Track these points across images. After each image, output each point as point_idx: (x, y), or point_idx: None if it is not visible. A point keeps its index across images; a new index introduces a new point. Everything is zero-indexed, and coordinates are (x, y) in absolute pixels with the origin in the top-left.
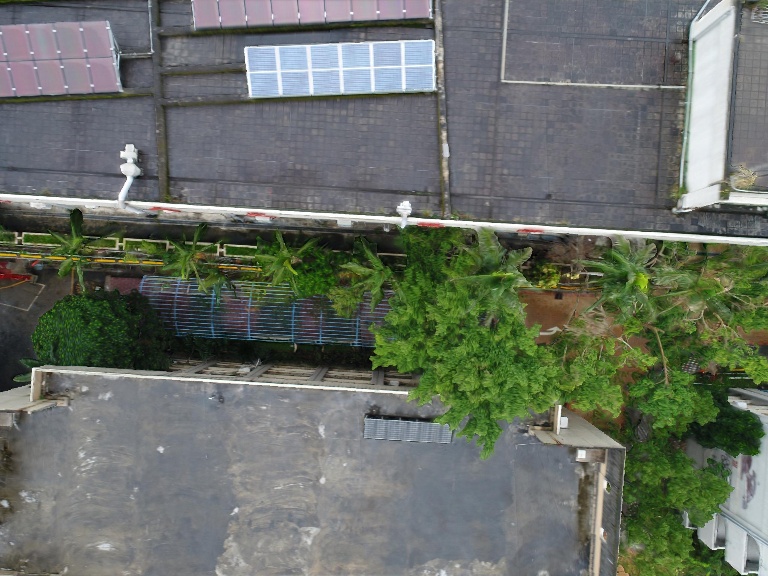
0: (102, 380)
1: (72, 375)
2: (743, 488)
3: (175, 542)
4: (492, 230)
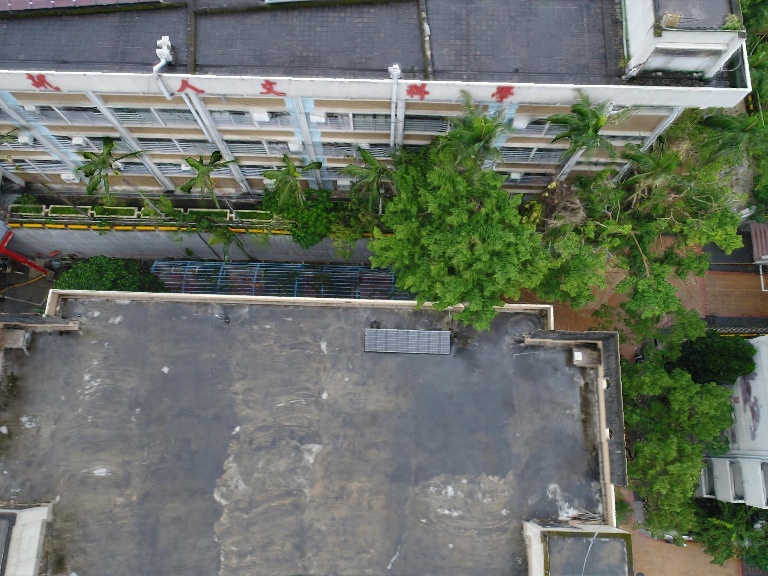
0: (114, 305)
1: (86, 301)
2: (748, 419)
3: (174, 464)
4: (470, 93)
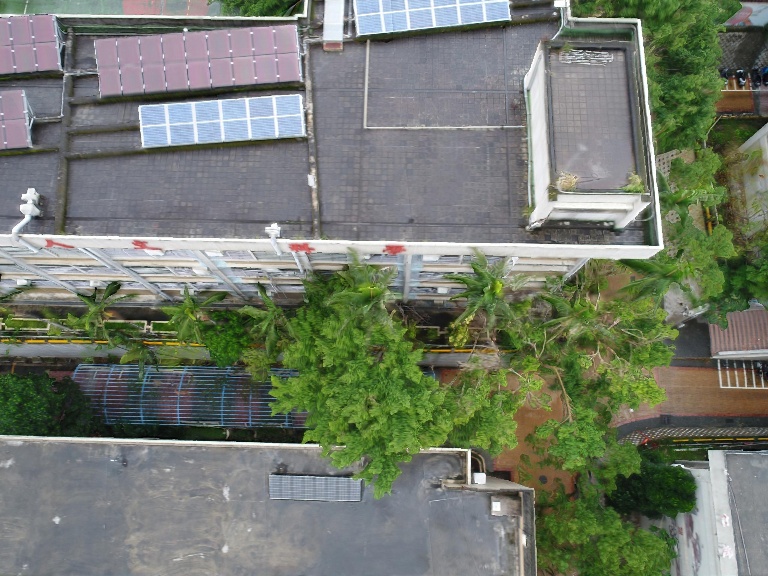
0: (5, 447)
1: None
2: (691, 556)
3: None
4: (358, 250)
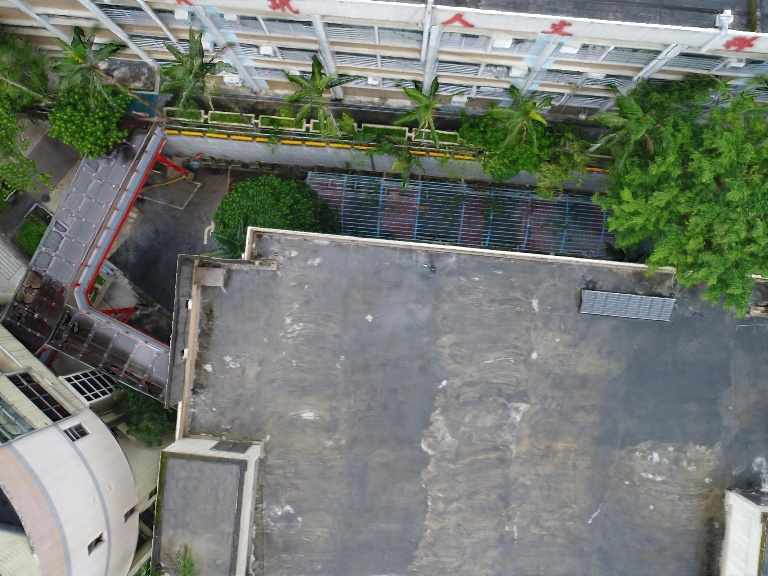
0: (312, 245)
1: (282, 239)
2: None
3: (381, 413)
4: None
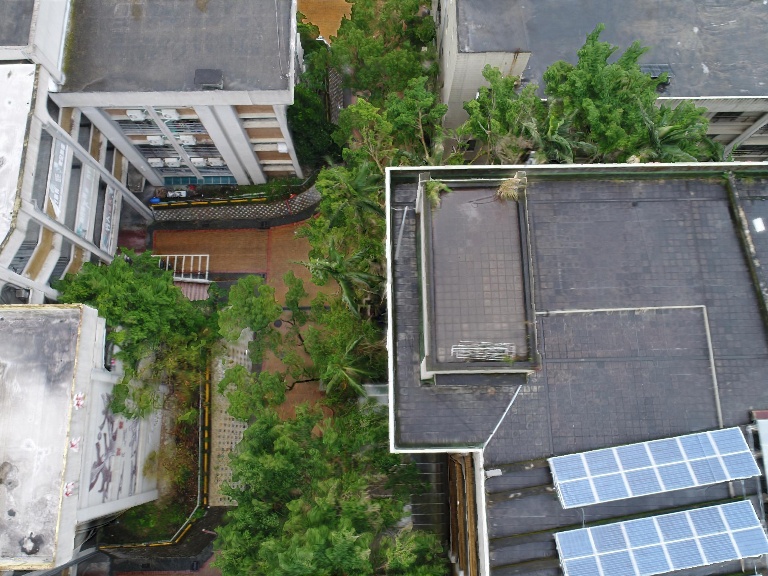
0: None
1: None
2: None
3: None
4: None
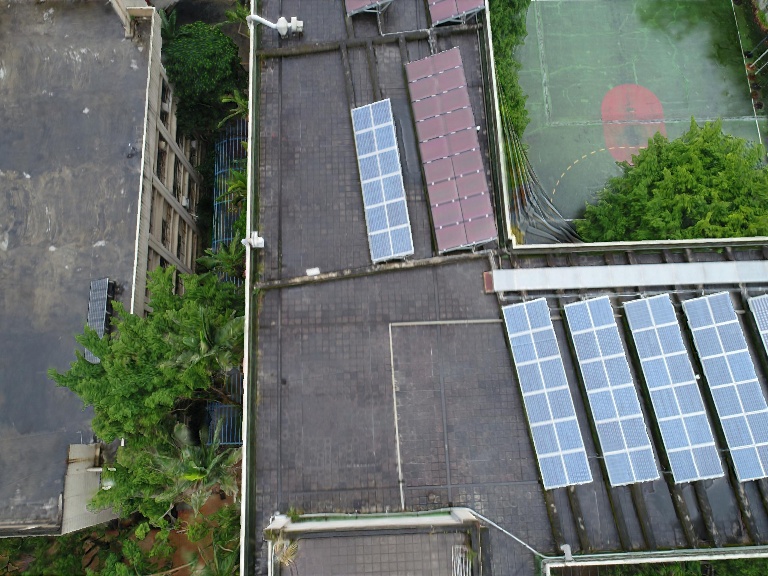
0: None
1: None
2: None
3: (1, 129)
4: None
